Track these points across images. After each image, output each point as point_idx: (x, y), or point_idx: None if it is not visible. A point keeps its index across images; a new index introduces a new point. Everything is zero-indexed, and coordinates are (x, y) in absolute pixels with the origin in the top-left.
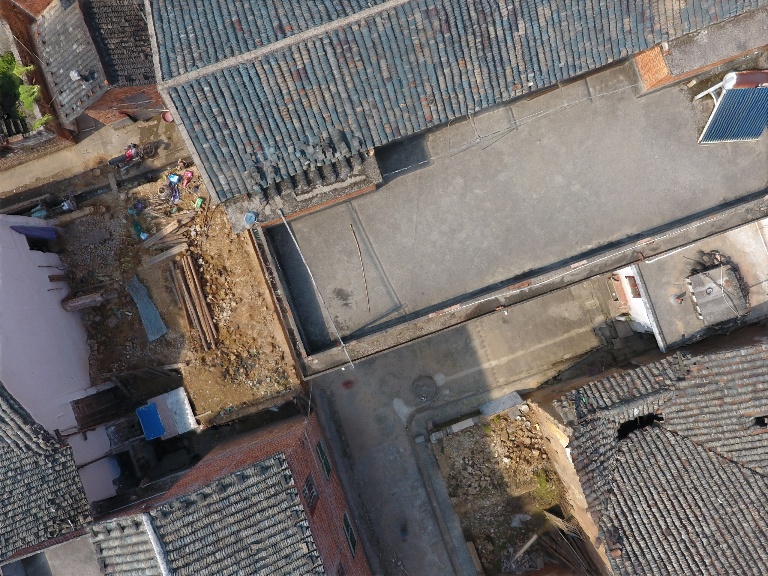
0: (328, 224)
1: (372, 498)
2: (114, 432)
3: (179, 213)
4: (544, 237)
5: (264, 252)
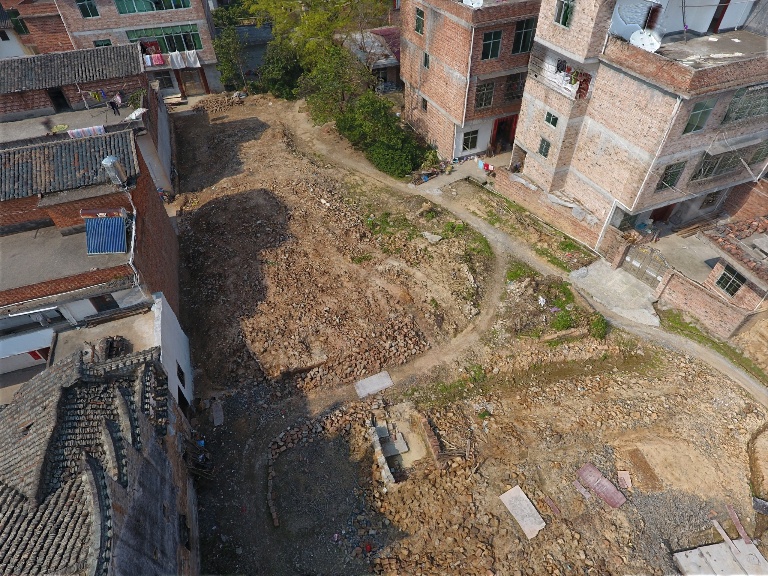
0: None
1: None
2: None
3: None
4: None
5: None
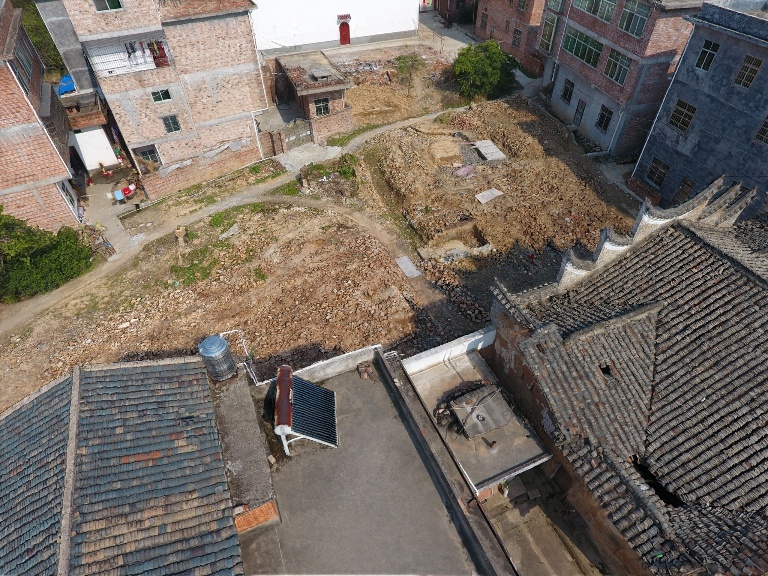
0: None
1: None
2: None
3: None
4: None
5: None
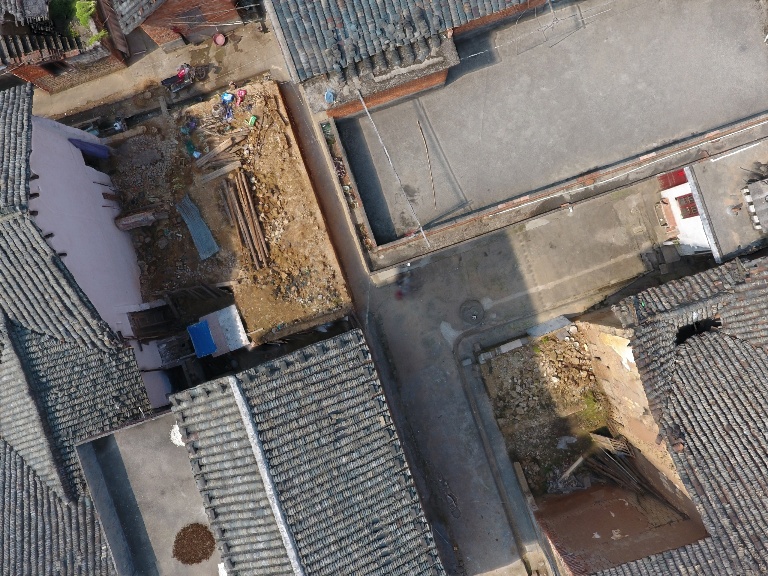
0: (395, 121)
1: (418, 420)
2: (165, 350)
3: (233, 131)
4: (610, 135)
5: (332, 148)
